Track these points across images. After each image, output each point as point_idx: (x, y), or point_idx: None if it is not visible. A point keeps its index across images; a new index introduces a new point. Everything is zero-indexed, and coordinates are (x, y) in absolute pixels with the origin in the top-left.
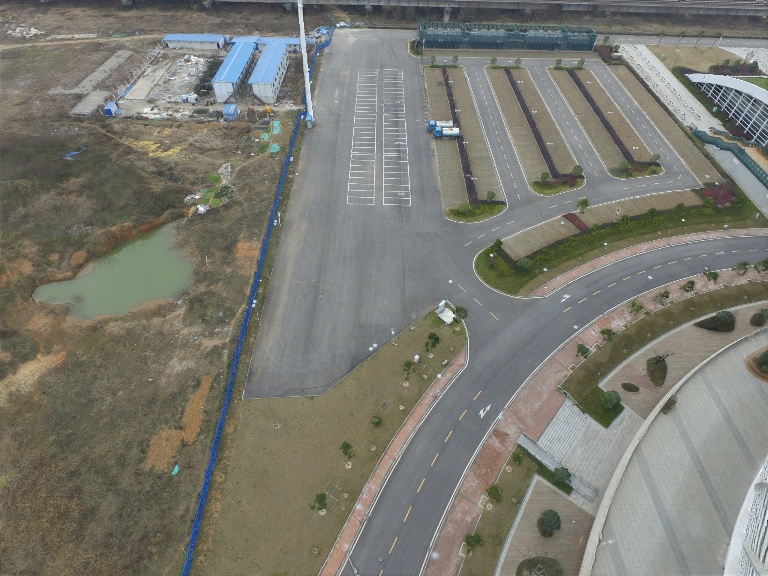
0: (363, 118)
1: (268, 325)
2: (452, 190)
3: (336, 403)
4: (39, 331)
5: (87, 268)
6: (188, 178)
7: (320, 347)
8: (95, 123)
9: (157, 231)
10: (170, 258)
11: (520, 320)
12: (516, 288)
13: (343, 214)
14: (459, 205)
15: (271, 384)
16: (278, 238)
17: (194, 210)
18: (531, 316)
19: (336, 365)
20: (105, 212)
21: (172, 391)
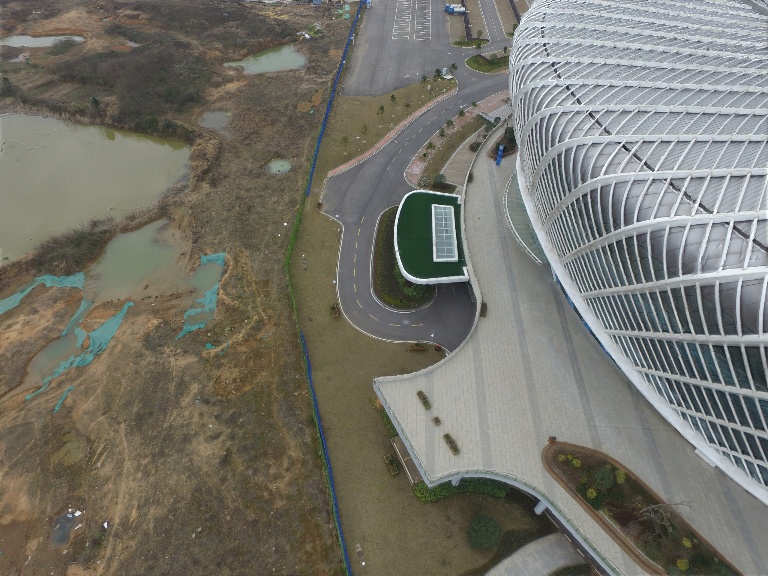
0: (403, 5)
1: (350, 76)
2: (457, 35)
3: (387, 98)
4: (231, 75)
5: (248, 57)
6: (297, 25)
7: (378, 83)
8: (234, 3)
9: (281, 49)
10: (292, 57)
11: (488, 80)
12: (488, 70)
13: (390, 42)
14: (460, 36)
15: (354, 92)
16: (353, 49)
17: (303, 37)
18: (494, 79)
19: (387, 89)
20: (253, 35)
21: (305, 92)
